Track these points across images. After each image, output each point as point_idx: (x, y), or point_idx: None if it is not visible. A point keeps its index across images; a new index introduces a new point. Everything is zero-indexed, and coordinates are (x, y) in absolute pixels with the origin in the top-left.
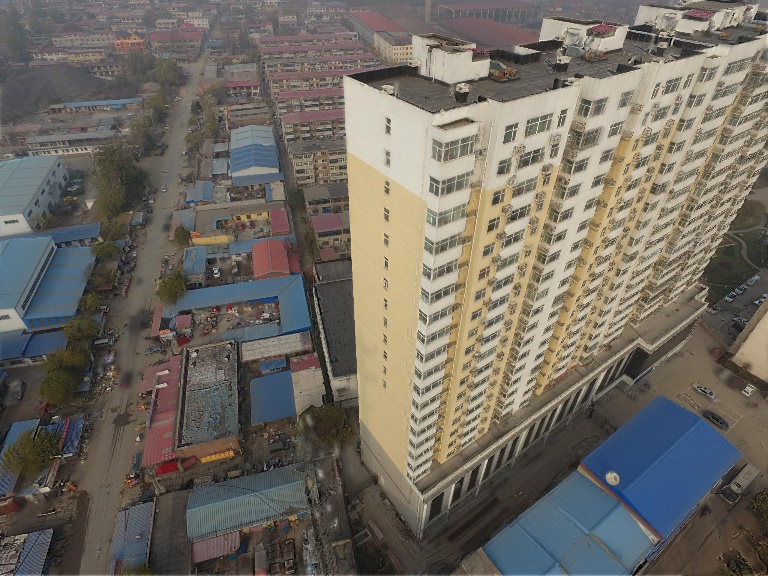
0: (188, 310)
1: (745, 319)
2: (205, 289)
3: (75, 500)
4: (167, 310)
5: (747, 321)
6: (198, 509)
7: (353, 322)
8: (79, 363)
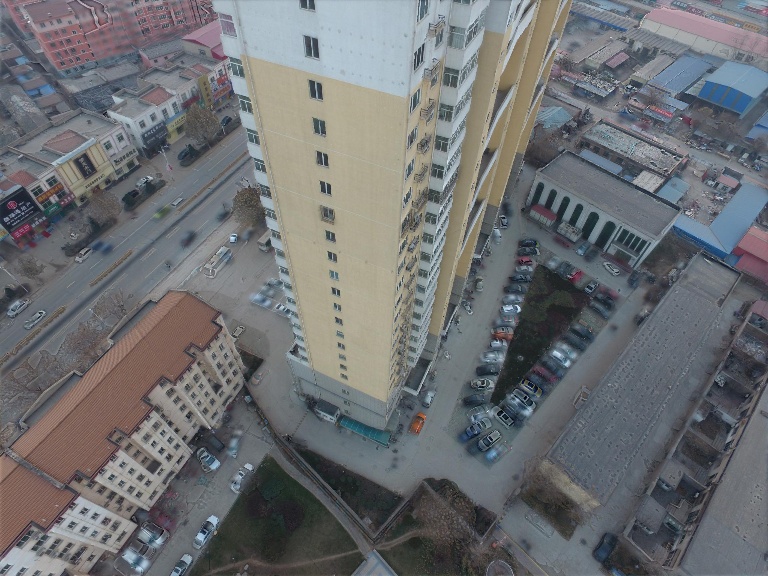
0: (741, 187)
1: (204, 463)
2: (764, 203)
3: (615, 110)
4: (755, 185)
5: (202, 458)
6: (558, 109)
7: (607, 192)
8: (719, 127)
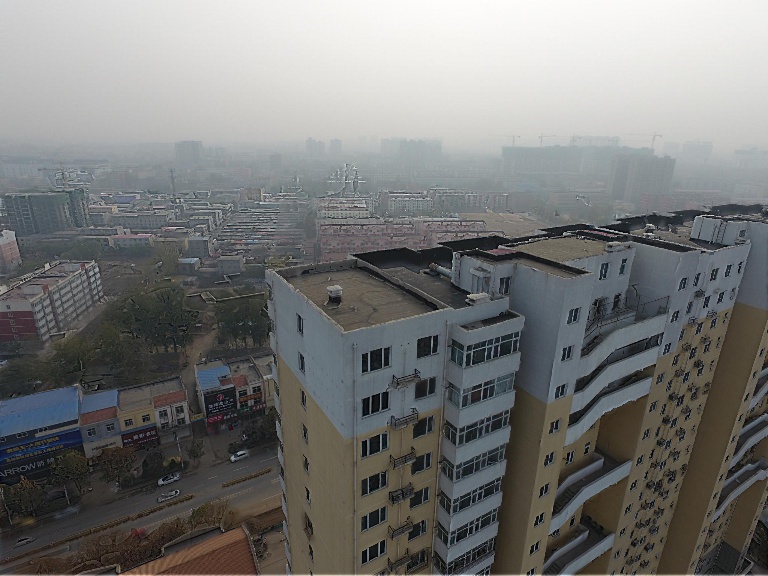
0: None
1: None
2: None
3: None
4: None
5: None
6: None
7: None
8: None
